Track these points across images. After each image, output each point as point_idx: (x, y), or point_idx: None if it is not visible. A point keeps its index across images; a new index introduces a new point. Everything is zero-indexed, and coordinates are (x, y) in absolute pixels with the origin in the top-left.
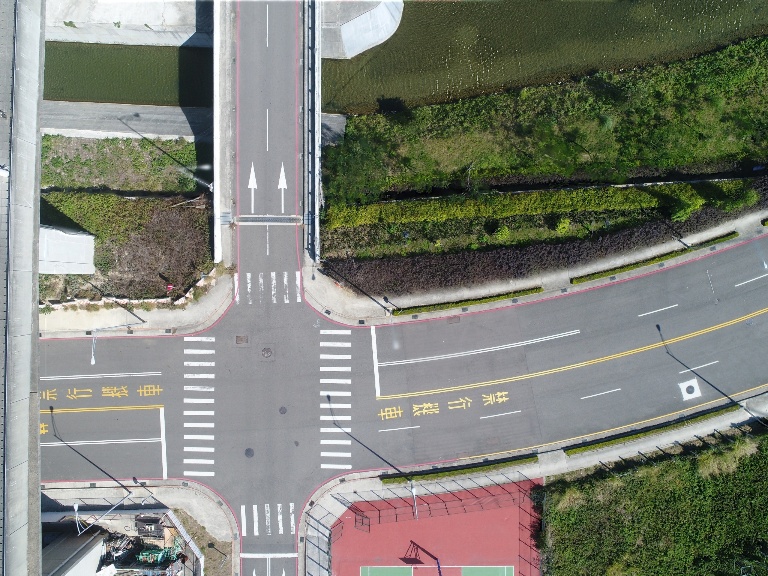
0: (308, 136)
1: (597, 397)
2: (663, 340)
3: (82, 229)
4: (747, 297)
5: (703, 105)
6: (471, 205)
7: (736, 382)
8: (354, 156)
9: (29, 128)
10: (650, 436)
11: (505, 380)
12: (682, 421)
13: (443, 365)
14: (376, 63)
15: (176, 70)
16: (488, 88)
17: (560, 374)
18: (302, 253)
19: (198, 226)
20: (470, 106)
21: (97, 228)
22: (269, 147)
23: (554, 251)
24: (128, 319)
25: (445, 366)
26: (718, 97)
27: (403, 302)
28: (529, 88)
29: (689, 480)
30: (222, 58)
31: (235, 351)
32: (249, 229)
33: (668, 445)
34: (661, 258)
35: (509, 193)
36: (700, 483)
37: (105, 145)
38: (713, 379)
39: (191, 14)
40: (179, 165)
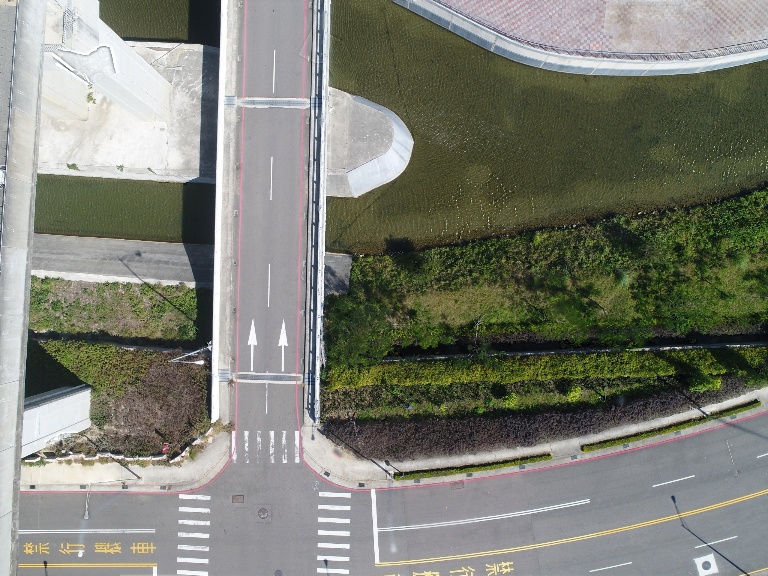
0: (310, 293)
1: (607, 570)
2: (678, 512)
3: (79, 381)
4: None
5: (725, 262)
6: (478, 370)
7: (756, 559)
8: (358, 307)
9: (12, 367)
10: None
11: (510, 550)
12: None
13: (445, 532)
14: (384, 201)
15: (180, 206)
16: (499, 229)
17: (568, 545)
18: (302, 412)
19: (196, 383)
20: (480, 251)
21: (94, 380)
22: (270, 303)
23: (564, 420)
24: (123, 474)
25: (447, 533)
26: (742, 254)
27: (405, 466)
28: (542, 232)
29: None
30: (224, 211)
31: (231, 511)
32: (248, 386)
33: None
34: (678, 427)
35: (518, 357)
36: None
37: (105, 289)
38: (731, 555)
39: (195, 158)
40: (179, 312)
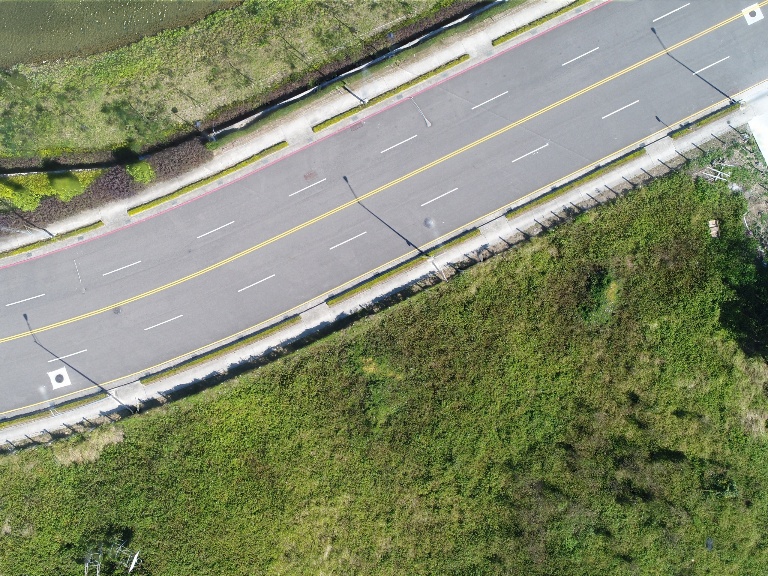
0: None
1: None
2: (30, 329)
3: None
4: (114, 286)
5: (83, 96)
6: None
7: (106, 371)
8: None
9: None
10: (19, 425)
11: None
12: (49, 410)
13: None
14: None
15: None
16: None
17: None
18: None
19: None
20: None
21: None
22: None
23: None
24: None
25: None
26: (99, 88)
27: None
28: None
29: (52, 468)
30: None
31: None
32: None
33: (37, 433)
34: (24, 248)
35: None
36: (61, 471)
37: None
38: (82, 368)
39: None
40: None
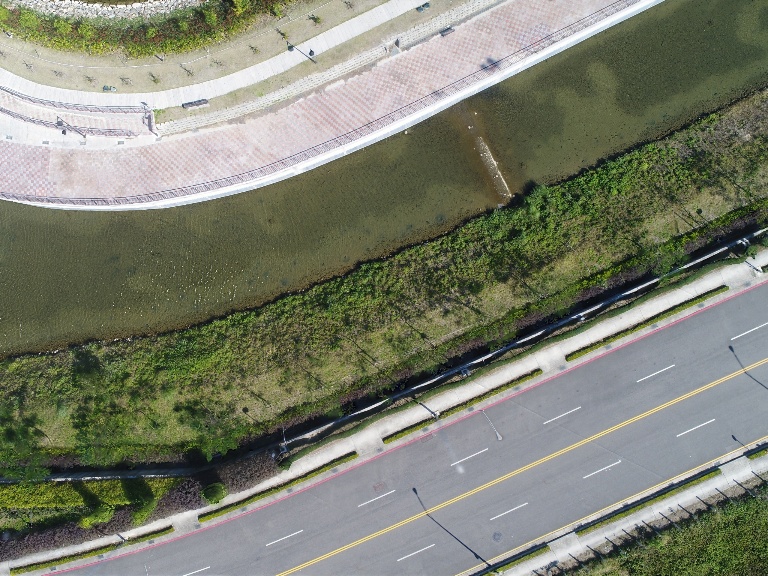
0: None
1: None
2: None
3: None
4: None
5: (156, 394)
6: None
7: None
8: None
9: None
10: None
11: None
12: None
13: None
14: None
15: None
16: None
17: None
18: None
19: None
20: None
21: None
22: None
23: None
24: None
25: None
26: (172, 386)
27: None
28: (22, 358)
29: None
30: None
31: None
32: None
33: None
34: (96, 552)
35: None
36: None
37: None
38: None
39: None
40: None
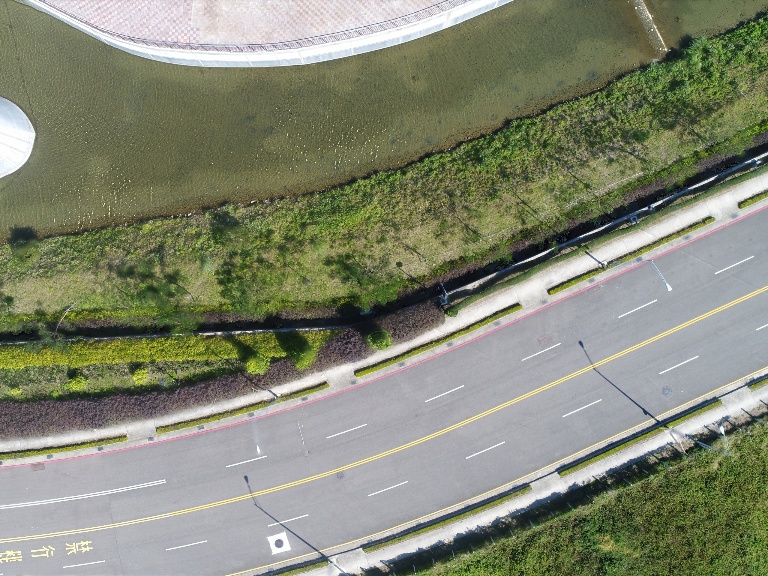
0: None
1: (183, 549)
2: (251, 492)
3: None
4: (338, 450)
5: (306, 248)
6: (47, 354)
7: (327, 536)
8: None
9: None
10: None
11: (89, 529)
12: (269, 575)
13: (26, 513)
14: (9, 192)
15: None
16: (119, 218)
17: (145, 524)
18: None
19: None
20: (92, 239)
21: None
22: None
23: (129, 403)
24: None
25: (28, 514)
26: (322, 240)
27: None
28: (155, 221)
29: None
30: None
31: None
32: None
33: None
34: (248, 409)
35: (89, 341)
36: None
37: None
38: (303, 533)
39: None
40: None
